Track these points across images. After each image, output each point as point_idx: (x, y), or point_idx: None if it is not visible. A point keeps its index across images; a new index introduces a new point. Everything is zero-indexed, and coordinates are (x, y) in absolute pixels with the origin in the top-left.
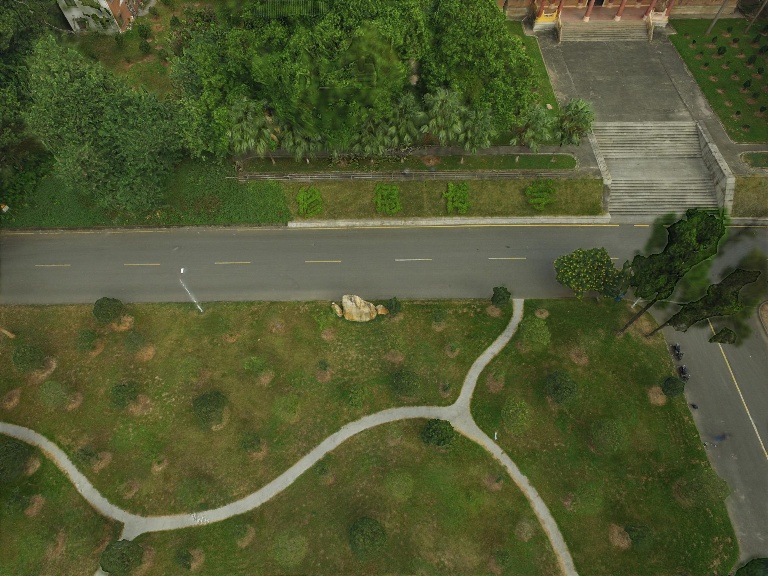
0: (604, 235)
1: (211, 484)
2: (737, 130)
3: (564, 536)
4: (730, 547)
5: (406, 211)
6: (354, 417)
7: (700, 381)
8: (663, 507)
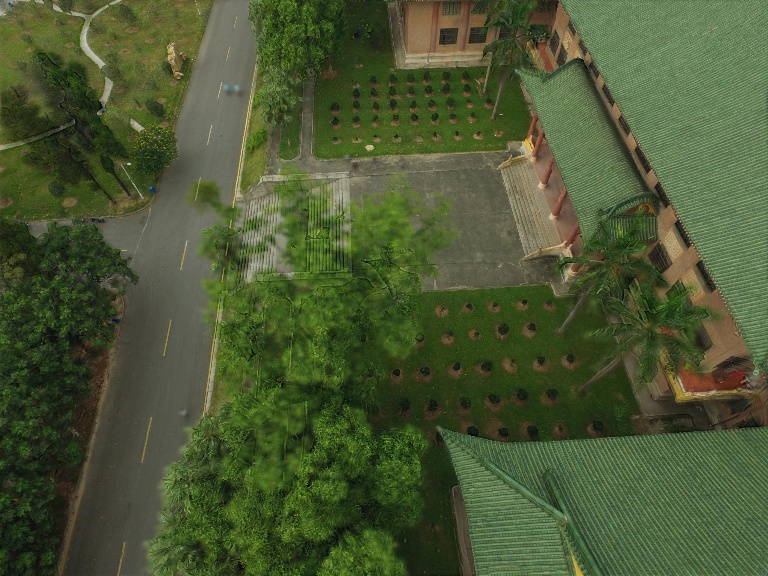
0: (223, 195)
1: (98, 33)
2: None
3: (11, 148)
4: None
5: None
6: None
7: None
8: (1, 191)
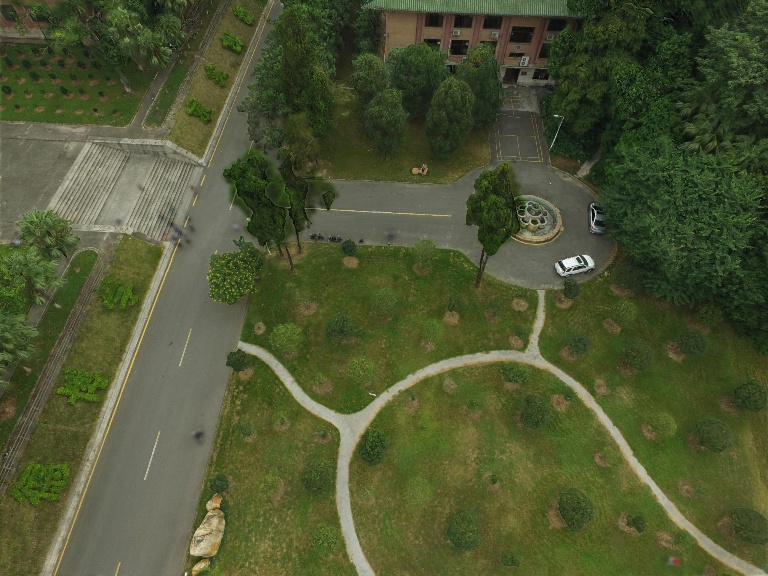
0: (187, 254)
1: None
2: (115, 119)
3: (452, 357)
4: (456, 255)
5: (73, 457)
6: (341, 545)
7: (342, 231)
8: (432, 284)
